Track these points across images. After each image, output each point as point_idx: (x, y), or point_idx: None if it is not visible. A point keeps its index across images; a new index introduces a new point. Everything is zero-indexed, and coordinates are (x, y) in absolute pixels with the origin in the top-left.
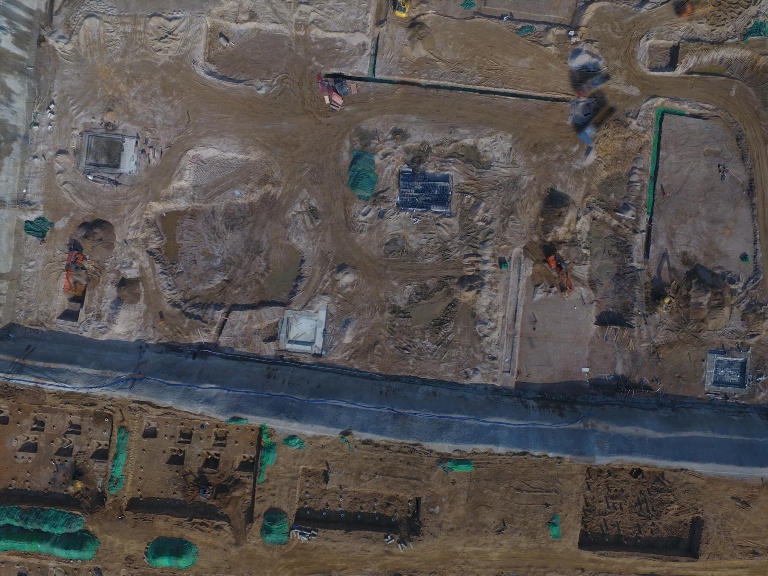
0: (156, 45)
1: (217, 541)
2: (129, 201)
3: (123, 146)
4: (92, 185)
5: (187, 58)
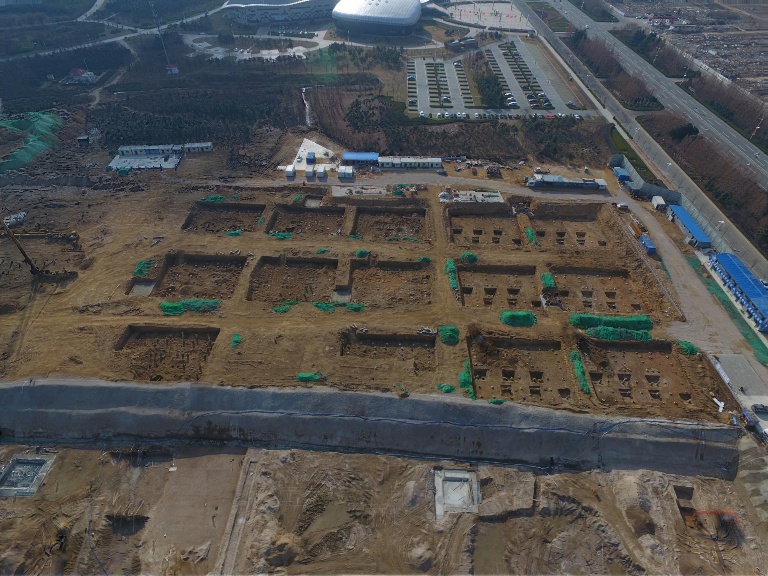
0: None
1: (488, 326)
2: None
3: None
4: None
5: None
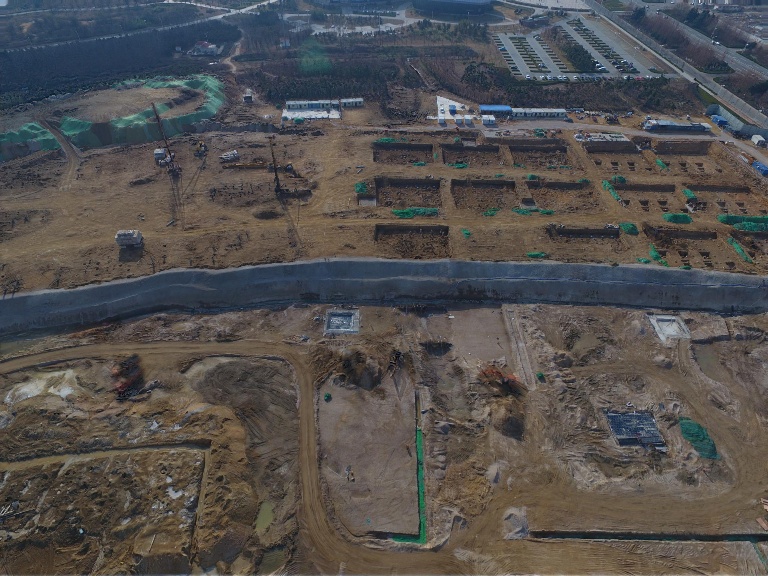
0: None
1: (657, 223)
2: None
3: None
4: None
5: None
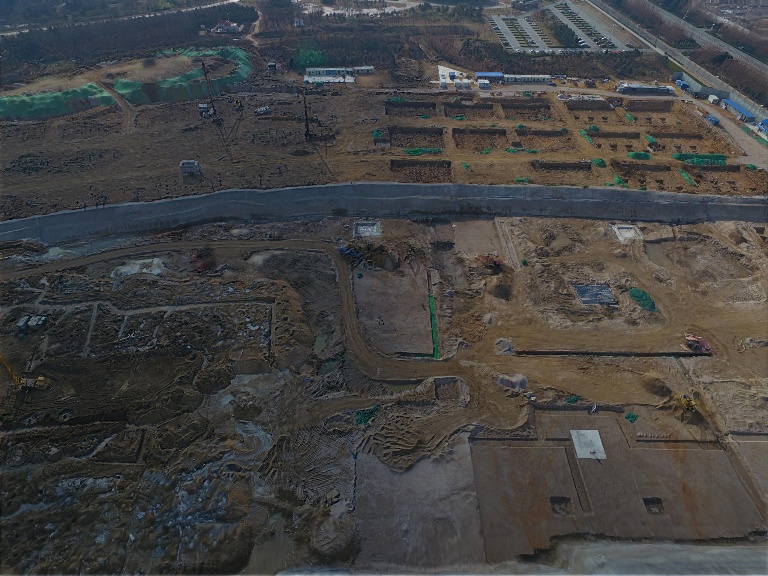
0: None
1: (622, 159)
2: None
3: None
4: None
5: None
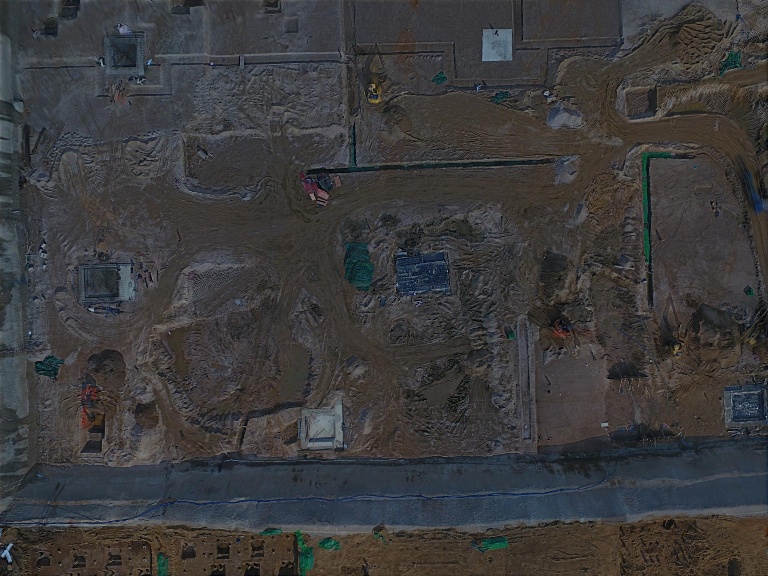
0: (136, 169)
1: None
2: (133, 327)
3: (119, 274)
4: (95, 317)
5: (169, 177)
